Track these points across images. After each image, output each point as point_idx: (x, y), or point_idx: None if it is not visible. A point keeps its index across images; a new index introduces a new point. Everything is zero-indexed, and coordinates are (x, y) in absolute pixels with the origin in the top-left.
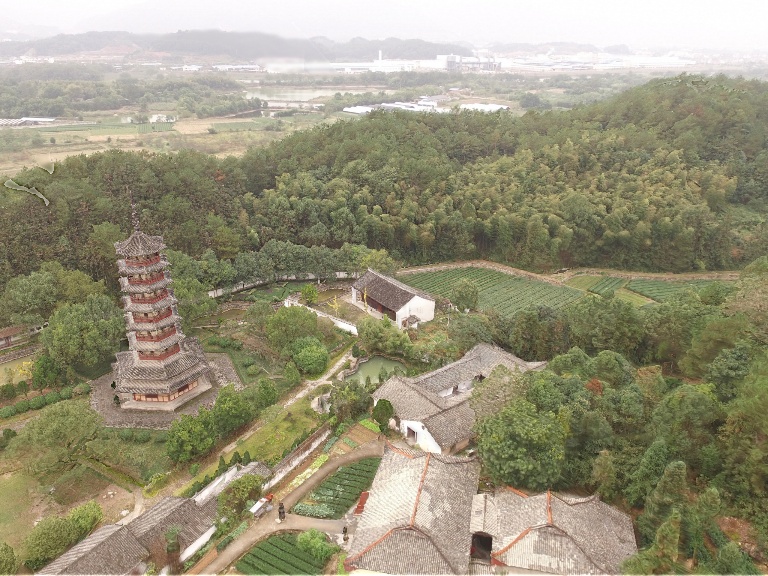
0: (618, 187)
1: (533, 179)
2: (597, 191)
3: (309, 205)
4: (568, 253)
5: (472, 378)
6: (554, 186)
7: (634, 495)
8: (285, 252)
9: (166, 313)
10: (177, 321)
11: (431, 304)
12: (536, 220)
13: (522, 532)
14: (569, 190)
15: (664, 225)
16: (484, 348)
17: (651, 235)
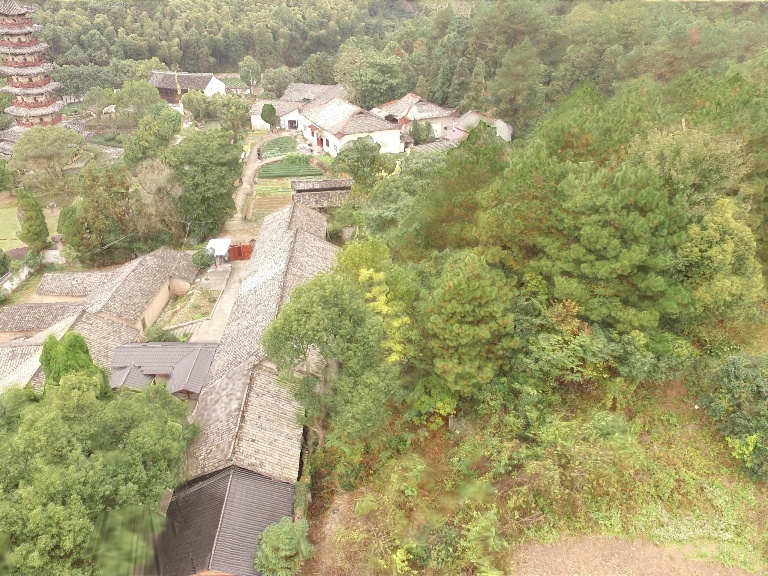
0: (301, 5)
1: (238, 2)
2: (289, 7)
3: (56, 30)
4: (288, 54)
5: (302, 99)
6: (256, 6)
7: (440, 97)
8: (57, 73)
9: (47, 79)
10: (58, 86)
11: (223, 86)
12: (260, 27)
13: (409, 107)
14: (270, 7)
15: (346, 23)
16: (296, 85)
17: (339, 33)
